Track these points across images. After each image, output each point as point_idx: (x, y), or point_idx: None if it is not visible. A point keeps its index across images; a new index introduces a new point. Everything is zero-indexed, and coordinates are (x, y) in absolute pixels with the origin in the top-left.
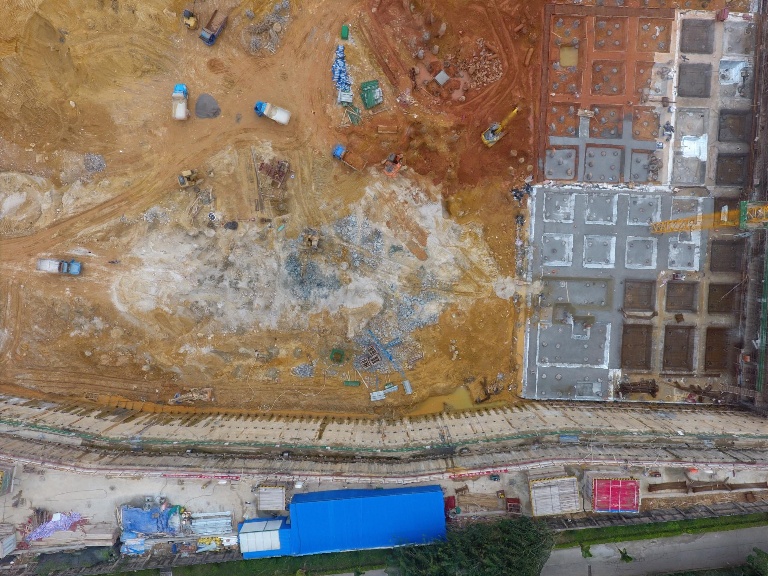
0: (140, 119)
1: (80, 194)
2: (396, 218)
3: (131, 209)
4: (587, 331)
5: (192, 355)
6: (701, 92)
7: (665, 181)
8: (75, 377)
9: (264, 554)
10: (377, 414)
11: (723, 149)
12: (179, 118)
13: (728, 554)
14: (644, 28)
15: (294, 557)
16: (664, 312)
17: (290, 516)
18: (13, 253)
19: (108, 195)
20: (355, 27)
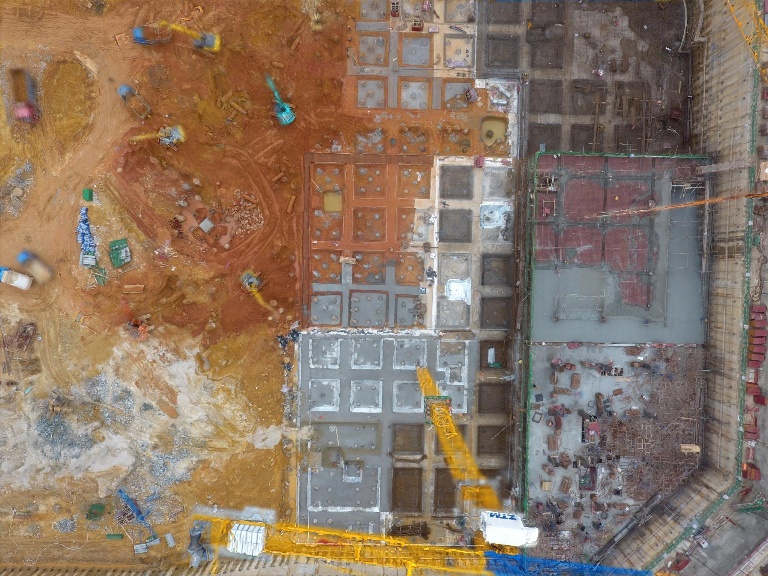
0: None
1: None
2: (145, 378)
3: None
4: (360, 473)
5: None
6: (464, 236)
7: (430, 325)
8: None
9: None
10: (145, 564)
11: (486, 293)
12: None
13: None
14: (405, 174)
15: None
16: (433, 455)
17: None
18: None
19: None
20: (101, 187)
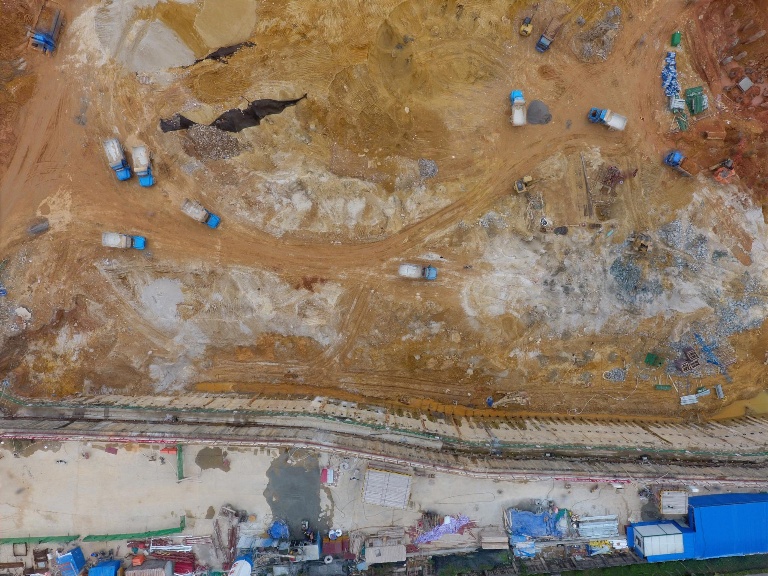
0: (473, 125)
1: (422, 199)
2: (723, 223)
3: (468, 214)
4: None
5: (521, 359)
6: None
7: None
8: (391, 380)
9: (668, 557)
10: (682, 418)
11: None
12: (518, 124)
13: None
14: None
15: (681, 560)
16: None
17: (694, 520)
18: (366, 258)
19: (448, 200)
20: (682, 34)
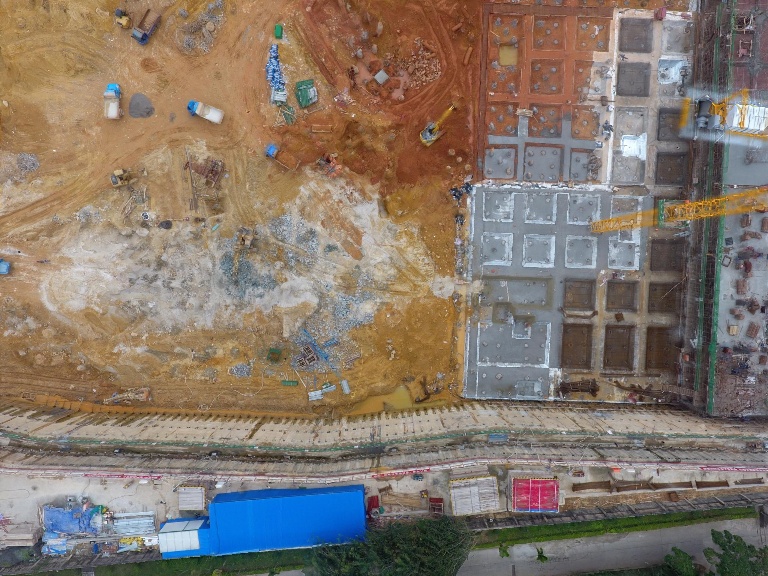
0: (73, 118)
1: (12, 193)
2: (331, 217)
3: (64, 208)
4: (528, 330)
5: (126, 355)
6: (640, 91)
7: (604, 180)
8: (12, 377)
9: (183, 554)
10: (316, 414)
11: (662, 148)
12: (111, 117)
13: (652, 554)
14: (583, 27)
15: (217, 557)
16: (604, 311)
17: (209, 516)
18: None
19: (40, 194)
20: (290, 26)
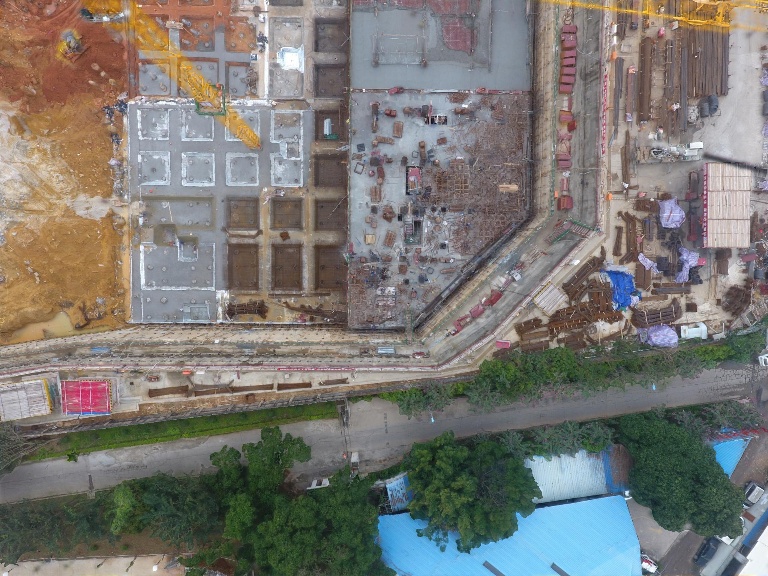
0: None
1: None
2: None
3: None
4: (196, 253)
5: None
6: (297, 1)
7: (262, 94)
8: None
9: None
10: None
11: (320, 60)
12: None
13: None
14: None
15: None
16: (269, 230)
17: None
18: None
19: None
20: None
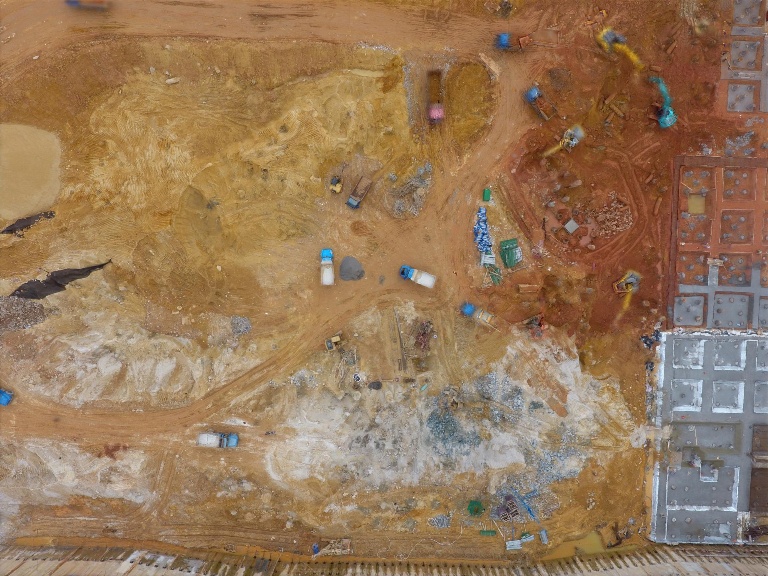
0: (285, 282)
1: (230, 360)
2: (537, 376)
3: (279, 373)
4: (714, 473)
5: (337, 514)
6: None
7: None
8: (215, 530)
9: None
10: (510, 560)
11: None
12: (327, 284)
13: None
14: None
15: None
16: None
17: None
18: (169, 424)
19: (257, 360)
20: (495, 188)
